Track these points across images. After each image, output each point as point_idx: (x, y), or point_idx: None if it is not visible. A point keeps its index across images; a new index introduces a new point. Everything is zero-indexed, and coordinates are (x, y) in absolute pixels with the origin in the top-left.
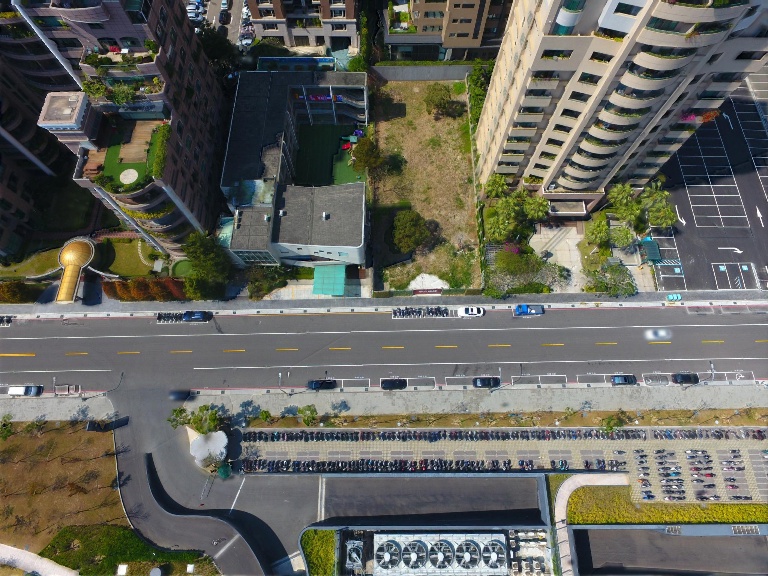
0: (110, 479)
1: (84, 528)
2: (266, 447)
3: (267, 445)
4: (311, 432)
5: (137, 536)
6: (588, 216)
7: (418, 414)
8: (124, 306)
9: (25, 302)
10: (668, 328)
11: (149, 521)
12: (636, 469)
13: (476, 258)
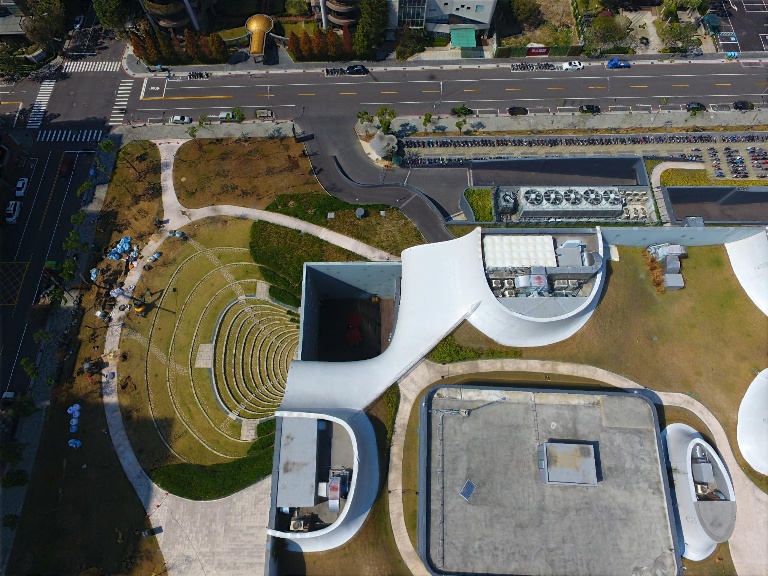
0: (307, 170)
1: (296, 194)
2: (424, 151)
3: (424, 150)
4: (458, 141)
5: (337, 199)
6: (660, 2)
7: (539, 129)
8: (297, 65)
9: (223, 58)
10: (728, 76)
11: (343, 192)
12: (710, 160)
13: (573, 33)
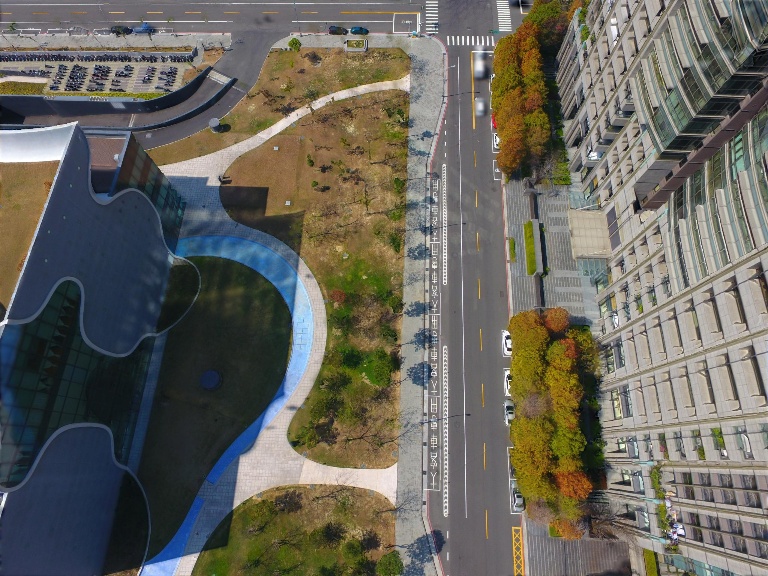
0: None
1: None
2: None
3: None
4: None
5: None
6: None
7: None
8: None
9: None
10: (128, 5)
11: None
12: None
13: None
